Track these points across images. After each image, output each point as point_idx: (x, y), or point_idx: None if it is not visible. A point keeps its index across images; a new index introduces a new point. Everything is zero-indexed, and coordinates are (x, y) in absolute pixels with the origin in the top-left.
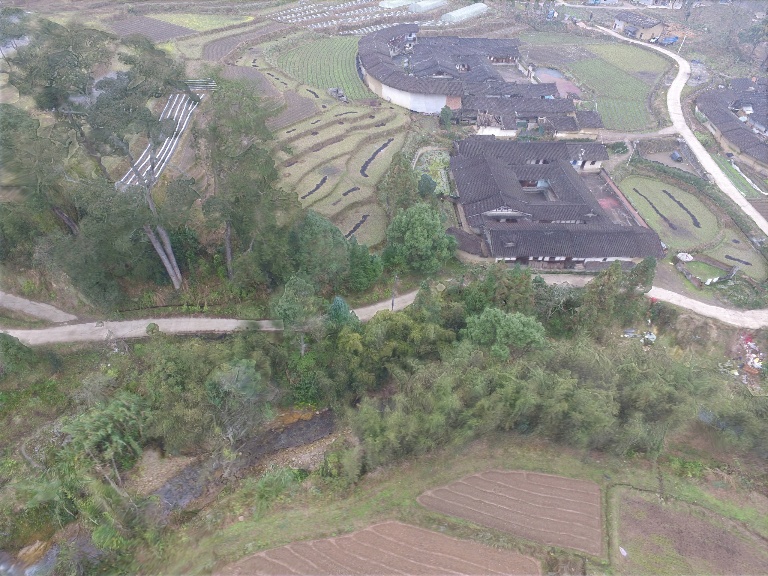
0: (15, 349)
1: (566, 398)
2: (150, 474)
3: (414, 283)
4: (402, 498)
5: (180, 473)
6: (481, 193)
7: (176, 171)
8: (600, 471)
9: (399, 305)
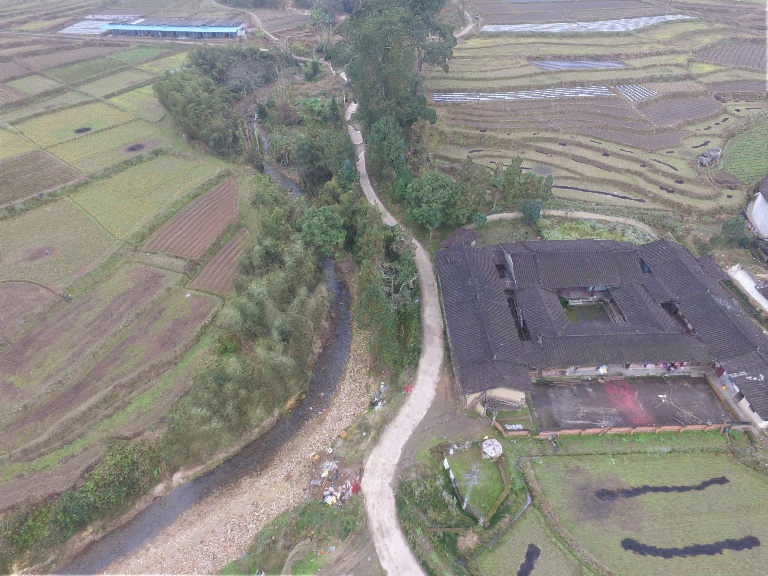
0: (331, 107)
1: (259, 243)
2: (293, 173)
3: (411, 226)
4: (246, 221)
5: (292, 181)
6: (538, 247)
7: None
8: (235, 296)
9: (388, 221)
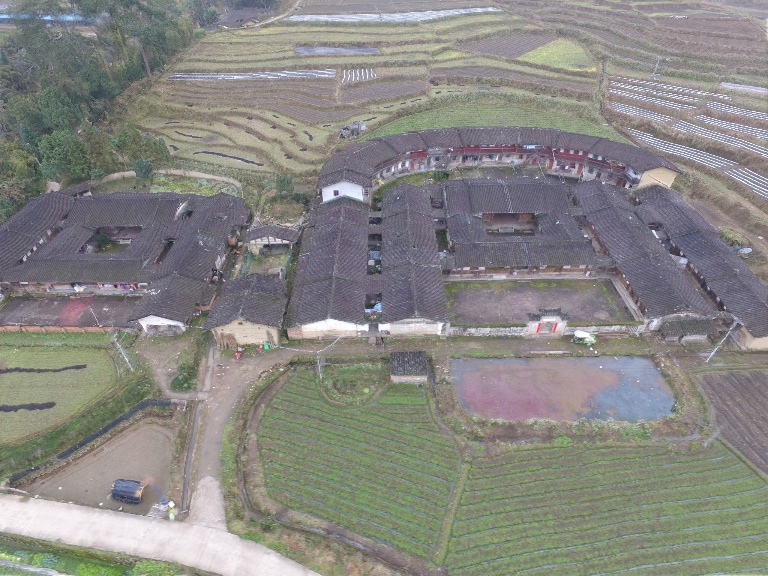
0: None
1: None
2: None
3: None
4: None
5: None
6: None
7: (204, 84)
8: None
9: None
